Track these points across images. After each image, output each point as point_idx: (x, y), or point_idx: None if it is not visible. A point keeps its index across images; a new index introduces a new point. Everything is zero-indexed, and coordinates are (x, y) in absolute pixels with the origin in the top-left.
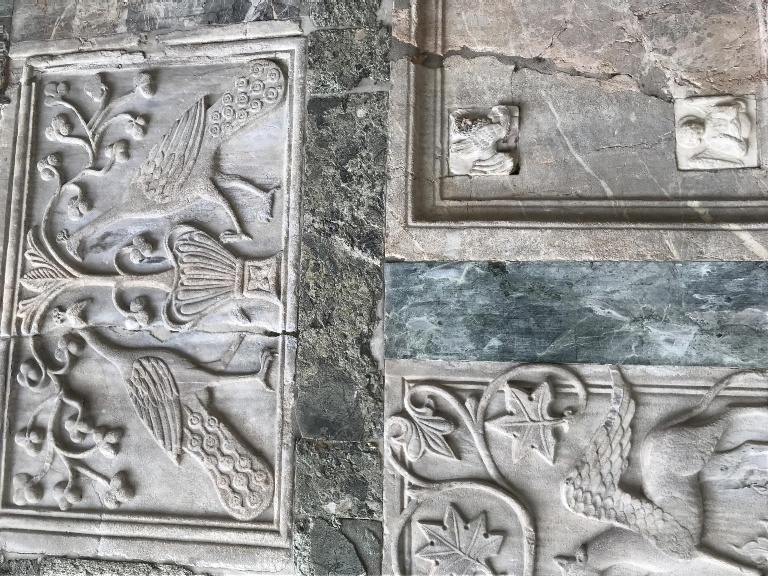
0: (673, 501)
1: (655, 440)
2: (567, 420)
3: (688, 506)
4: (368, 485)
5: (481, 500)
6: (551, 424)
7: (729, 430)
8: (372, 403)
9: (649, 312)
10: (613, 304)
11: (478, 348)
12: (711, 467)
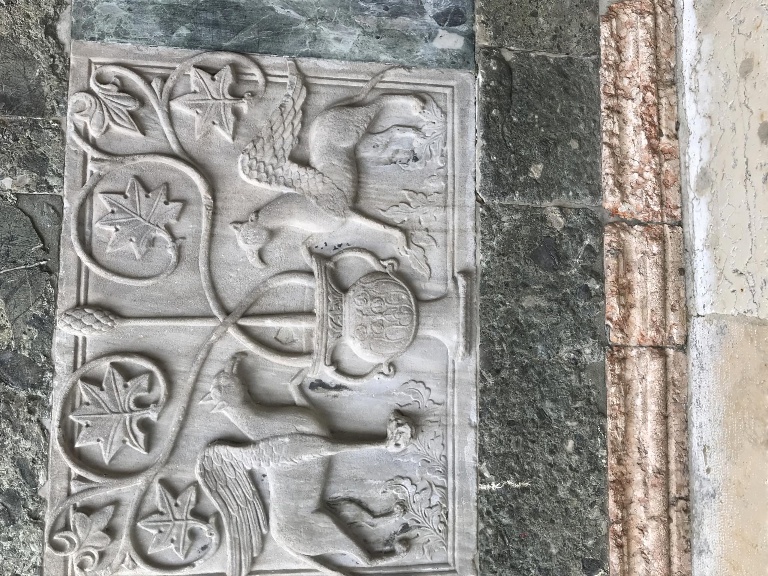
0: (332, 167)
1: (320, 117)
2: (246, 100)
3: (344, 172)
4: (48, 161)
5: (164, 173)
6: (231, 103)
7: (382, 116)
8: (55, 81)
9: (322, 14)
10: (292, 5)
11: (167, 35)
12: (366, 144)
